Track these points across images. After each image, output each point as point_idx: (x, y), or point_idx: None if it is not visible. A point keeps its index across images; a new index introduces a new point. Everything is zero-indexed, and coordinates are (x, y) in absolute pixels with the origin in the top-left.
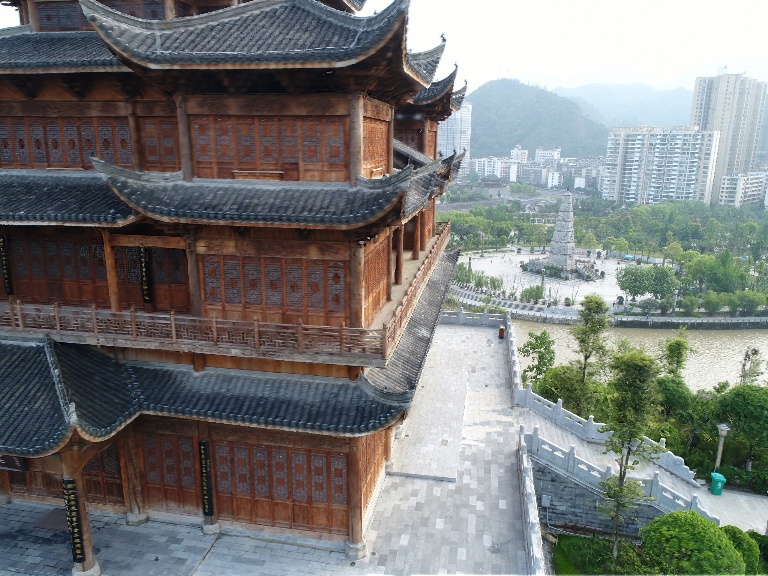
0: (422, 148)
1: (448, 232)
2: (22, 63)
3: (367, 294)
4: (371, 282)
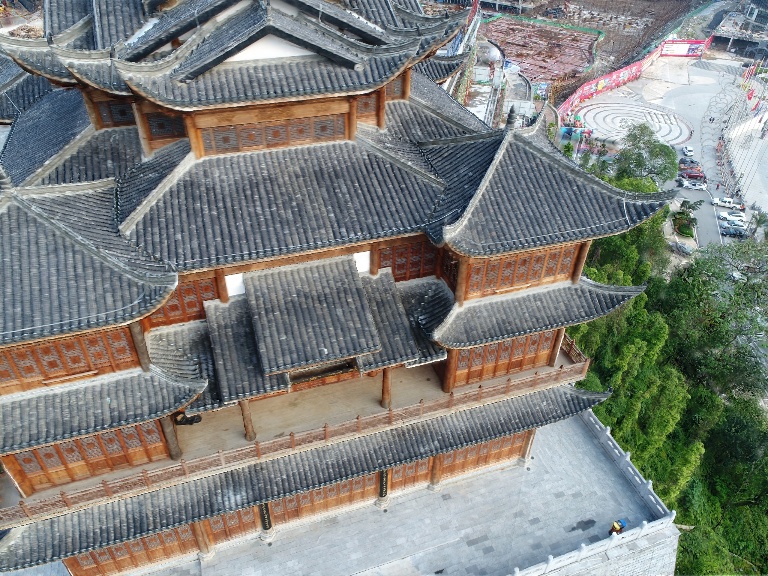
0: (456, 284)
1: (568, 374)
2: (1, 154)
3: (59, 463)
4: (77, 454)
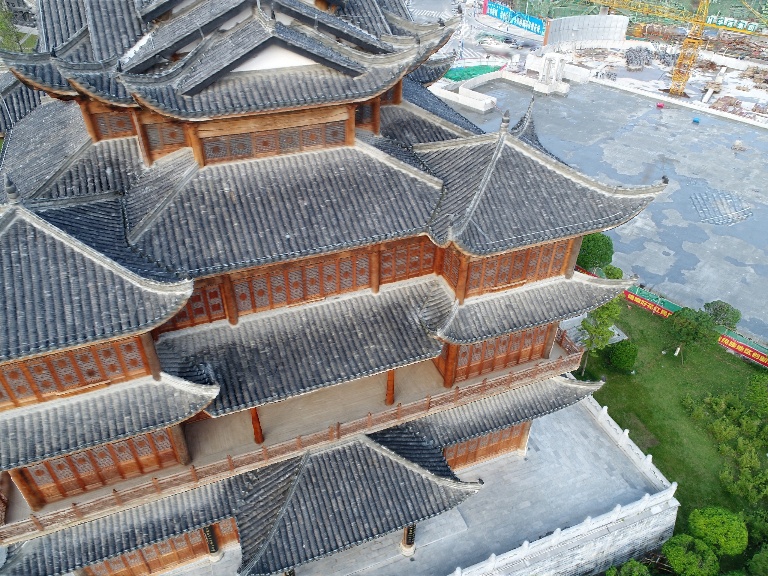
0: None
1: (1, 514)
2: None
3: None
4: None
